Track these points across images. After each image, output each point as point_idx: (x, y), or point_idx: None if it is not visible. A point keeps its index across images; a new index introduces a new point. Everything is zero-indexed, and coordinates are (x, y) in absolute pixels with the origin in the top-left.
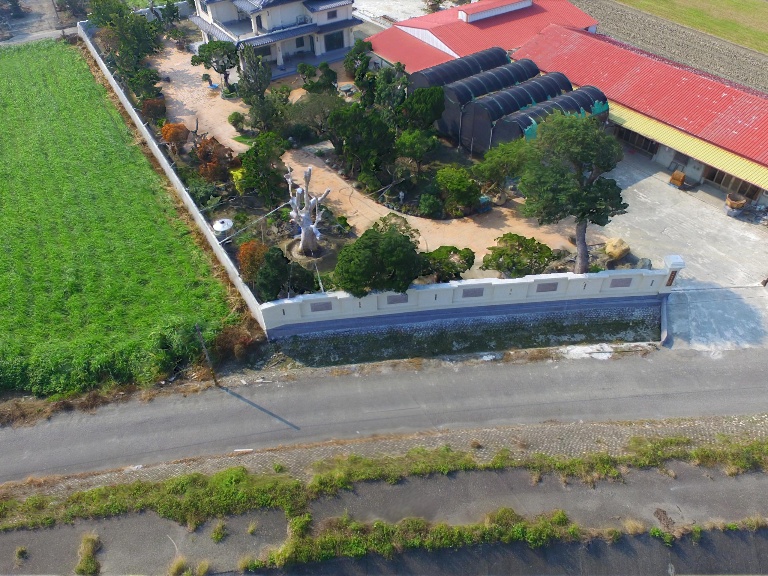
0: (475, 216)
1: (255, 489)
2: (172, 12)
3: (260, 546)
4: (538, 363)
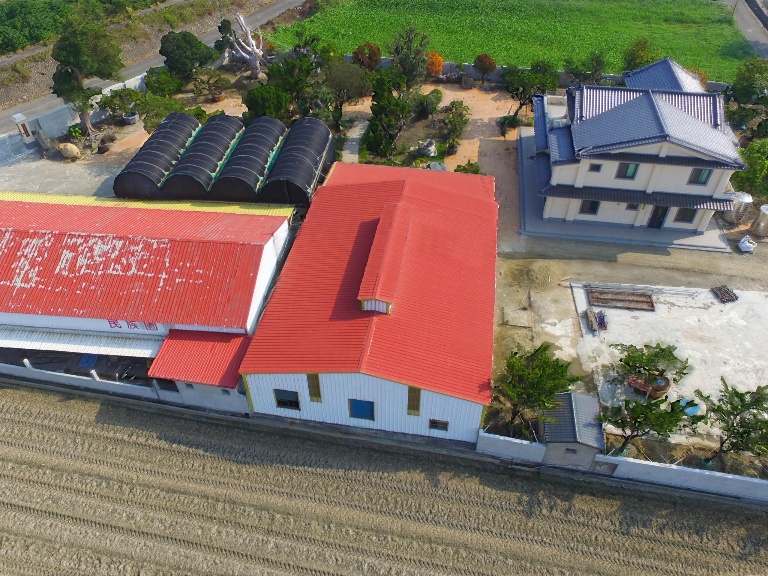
0: None
1: (155, 14)
2: (760, 125)
3: (142, 13)
4: None
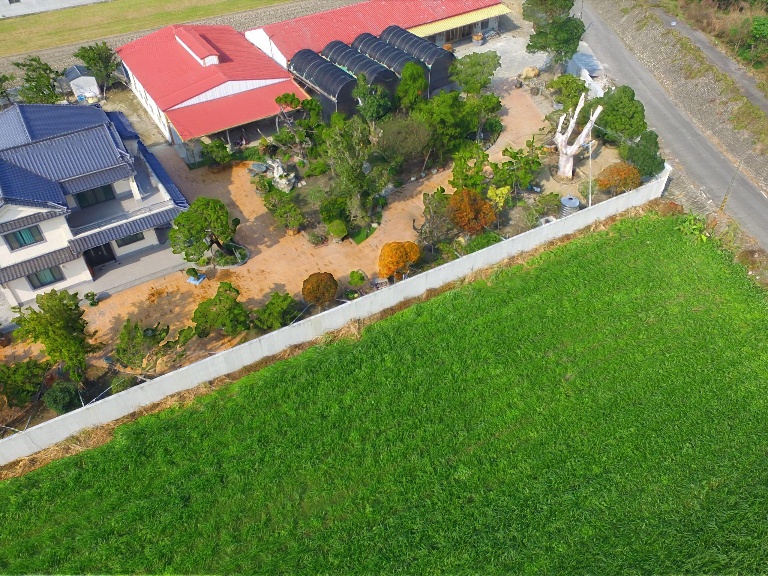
0: None
1: None
2: None
3: None
4: None
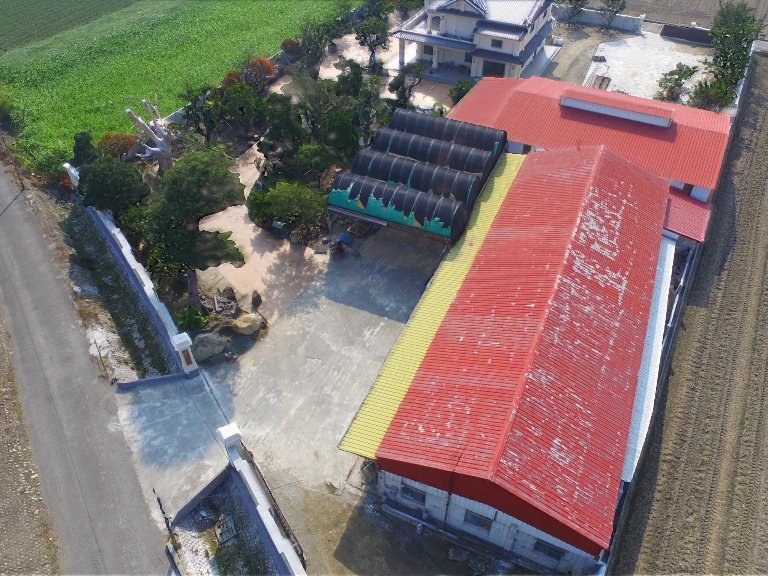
0: (267, 233)
1: None
2: None
3: None
4: (76, 316)
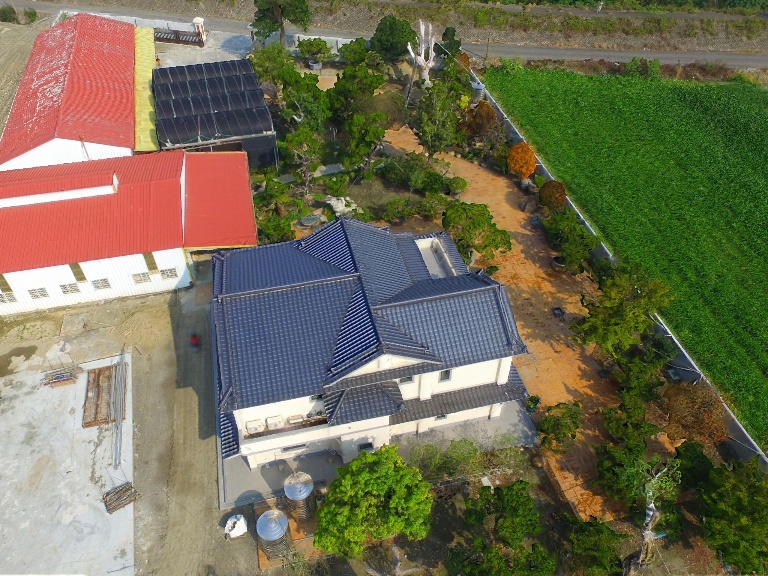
0: None
1: (472, 9)
2: (587, 523)
3: None
4: None
